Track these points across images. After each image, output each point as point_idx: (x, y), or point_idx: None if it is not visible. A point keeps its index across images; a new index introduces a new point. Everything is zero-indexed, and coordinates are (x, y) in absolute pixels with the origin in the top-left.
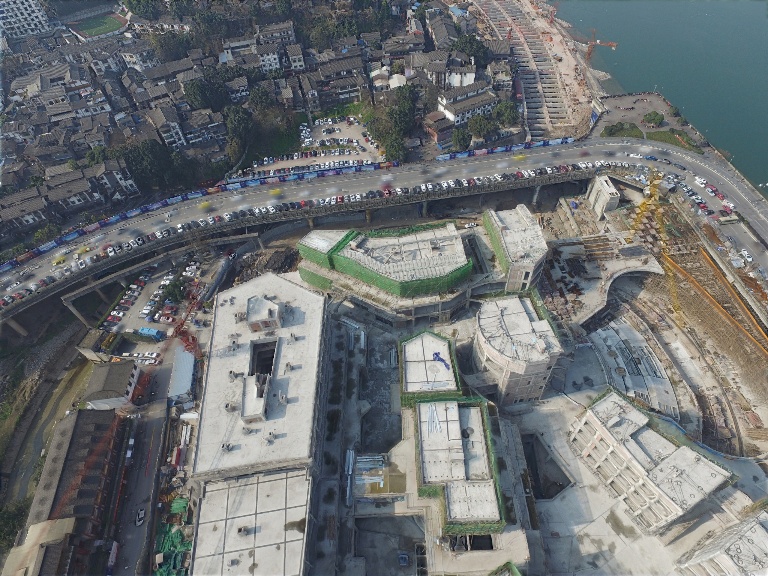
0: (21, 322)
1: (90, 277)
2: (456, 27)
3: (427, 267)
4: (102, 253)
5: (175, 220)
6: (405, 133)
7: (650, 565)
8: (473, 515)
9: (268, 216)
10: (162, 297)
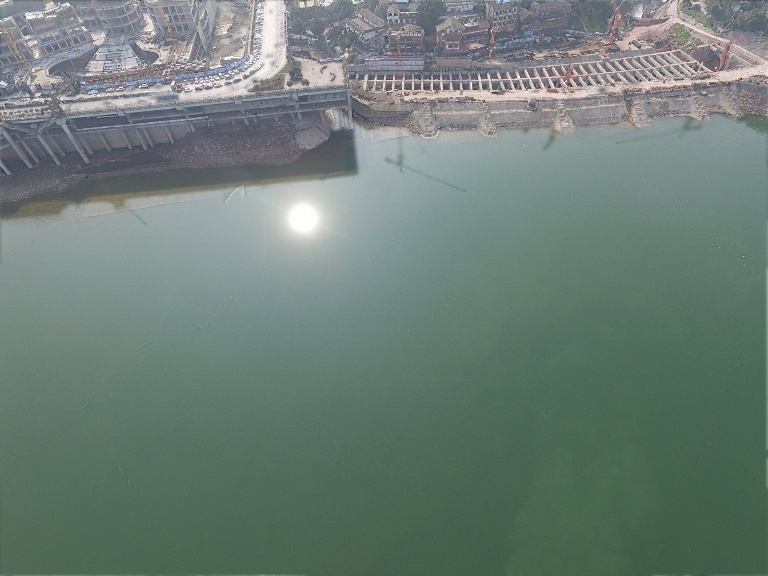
0: None
1: None
2: (479, 4)
3: None
4: None
5: None
6: None
7: None
8: None
9: None
10: None
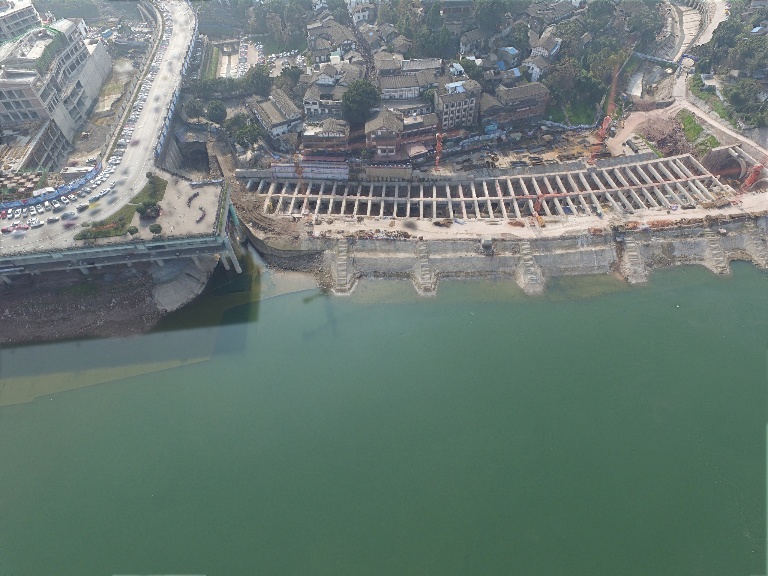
0: (147, 8)
1: (148, 7)
2: (426, 91)
3: (7, 52)
4: (159, 3)
5: (178, 16)
6: (266, 96)
7: None
8: None
9: None
10: None
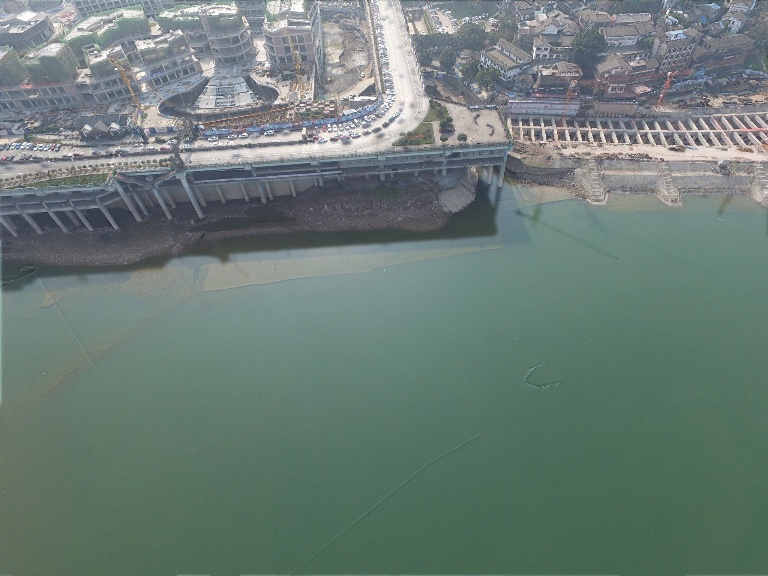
0: None
1: None
2: (645, 39)
3: (275, 7)
4: None
5: None
6: None
7: (142, 75)
8: (163, 14)
9: (365, 2)
10: (330, 0)
